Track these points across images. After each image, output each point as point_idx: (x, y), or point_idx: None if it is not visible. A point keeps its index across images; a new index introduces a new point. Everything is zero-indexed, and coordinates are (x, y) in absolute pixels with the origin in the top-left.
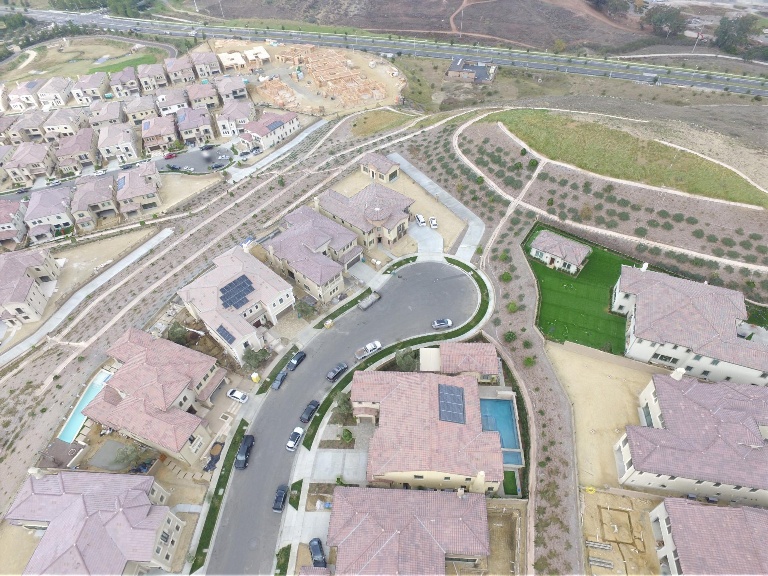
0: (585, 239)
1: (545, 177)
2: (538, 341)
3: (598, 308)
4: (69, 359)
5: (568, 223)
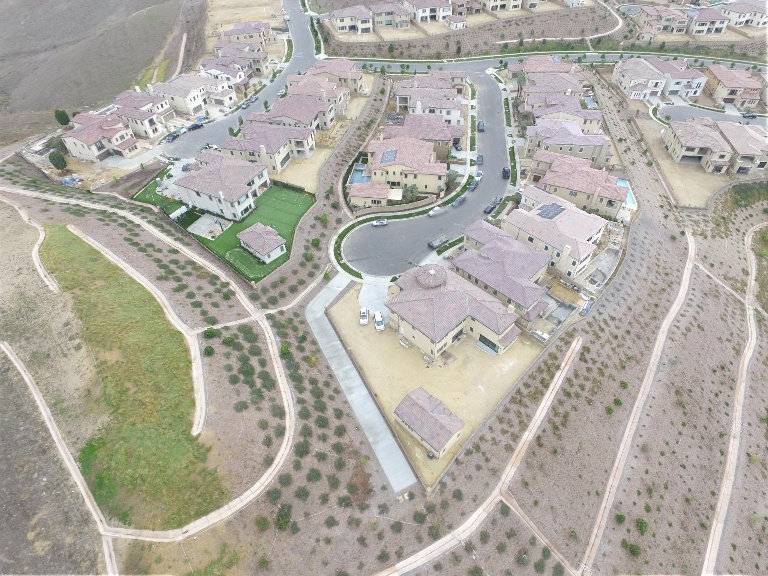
0: (224, 261)
1: (210, 317)
2: (319, 196)
3: (263, 211)
4: (693, 252)
5: (225, 279)
